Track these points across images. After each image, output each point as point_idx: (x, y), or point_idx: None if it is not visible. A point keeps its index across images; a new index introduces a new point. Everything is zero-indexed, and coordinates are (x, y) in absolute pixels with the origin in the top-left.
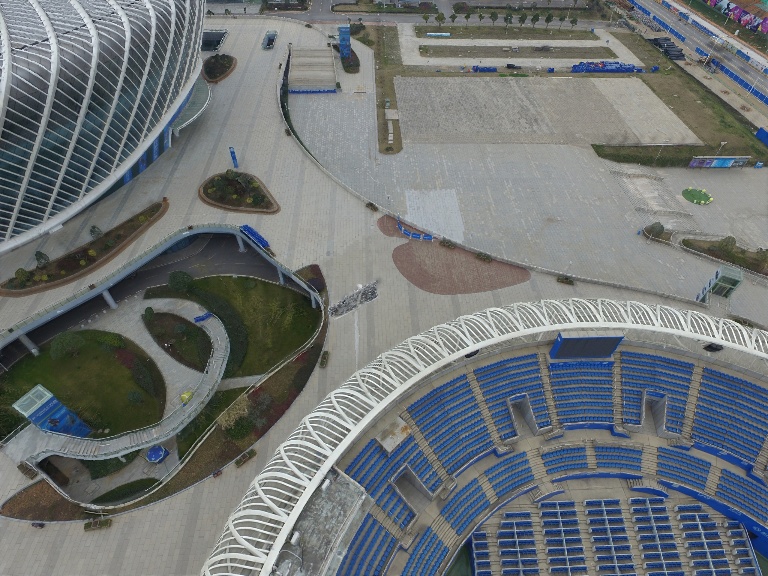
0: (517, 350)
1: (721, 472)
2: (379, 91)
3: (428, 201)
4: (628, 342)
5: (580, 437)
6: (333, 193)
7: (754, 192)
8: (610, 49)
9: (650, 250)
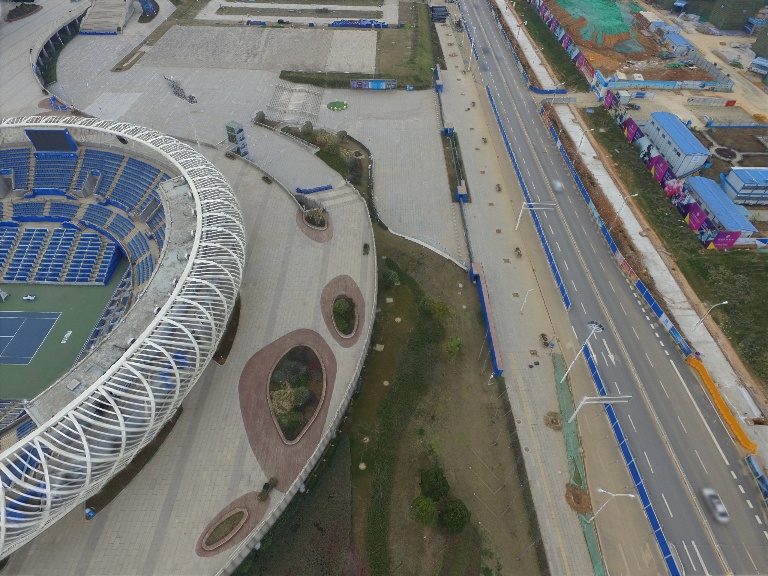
0: (19, 146)
1: (116, 216)
2: (152, 34)
3: (114, 99)
4: (92, 144)
5: (45, 198)
6: (27, 85)
7: (387, 105)
8: (382, 12)
9: (249, 130)
